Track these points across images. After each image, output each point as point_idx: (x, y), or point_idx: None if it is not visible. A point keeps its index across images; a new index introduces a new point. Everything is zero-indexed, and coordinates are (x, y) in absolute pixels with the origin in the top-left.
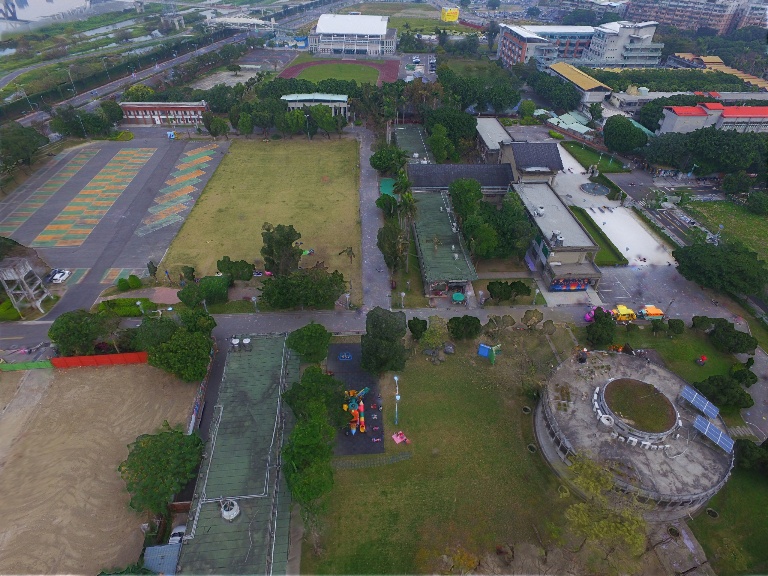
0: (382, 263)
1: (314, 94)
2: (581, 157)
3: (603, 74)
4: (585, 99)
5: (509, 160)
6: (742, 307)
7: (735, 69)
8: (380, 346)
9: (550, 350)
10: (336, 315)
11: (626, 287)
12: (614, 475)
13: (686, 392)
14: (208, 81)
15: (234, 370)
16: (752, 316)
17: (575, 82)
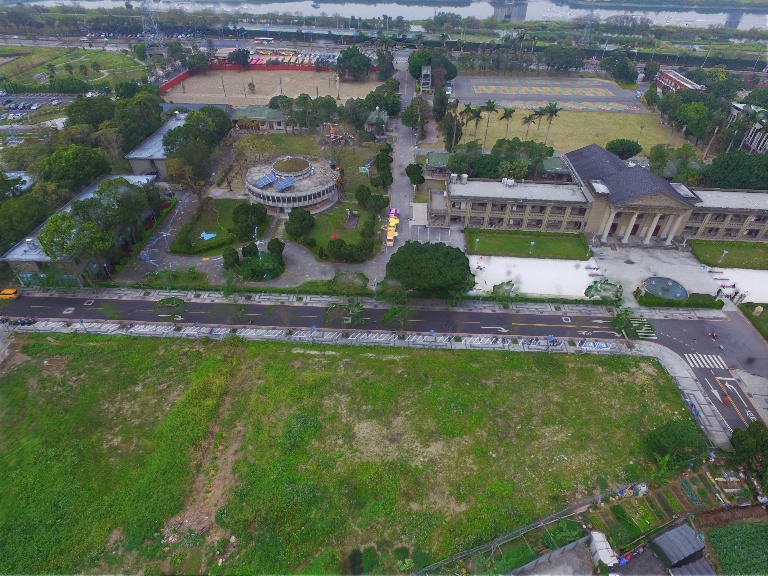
0: None
1: None
2: None
3: None
4: None
5: None
6: None
7: None
8: None
9: None
10: (410, 141)
11: (432, 242)
12: None
13: (291, 179)
14: None
15: None
16: None
17: None
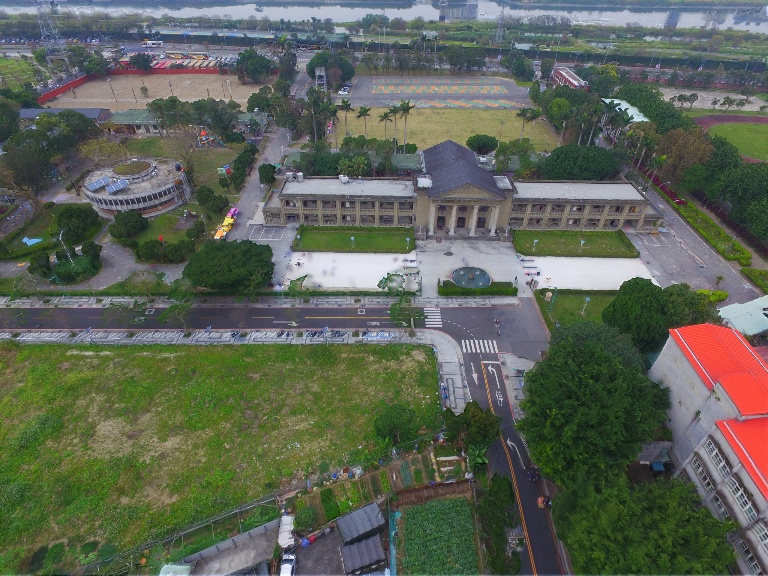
0: None
1: (631, 107)
2: (605, 301)
3: None
4: None
5: None
6: None
7: None
8: None
9: (217, 193)
10: (285, 141)
11: (262, 240)
12: None
13: (125, 182)
14: (705, 93)
15: (245, 114)
16: None
17: None
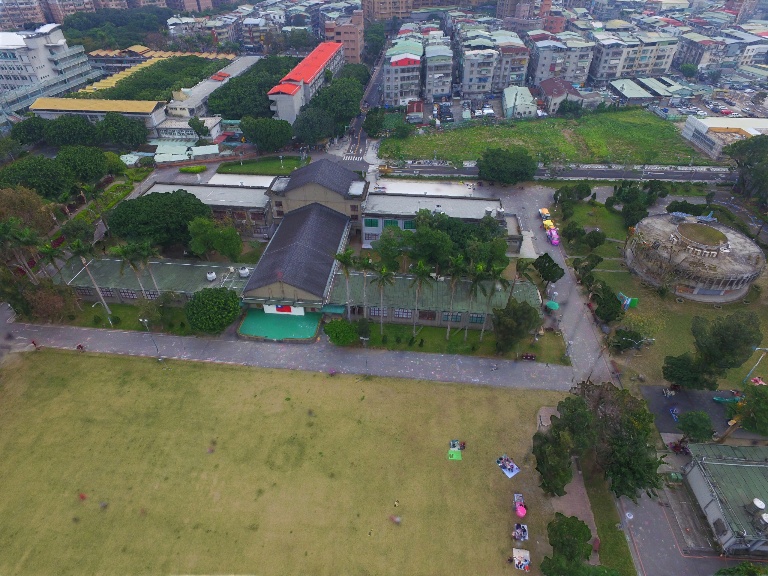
0: (478, 363)
1: None
2: (261, 171)
3: (119, 92)
4: (154, 123)
5: (310, 200)
6: (527, 181)
7: (170, 51)
8: (762, 338)
9: (602, 272)
10: None
11: None
12: (761, 264)
13: (677, 215)
14: None
15: None
16: (536, 181)
17: (118, 110)
